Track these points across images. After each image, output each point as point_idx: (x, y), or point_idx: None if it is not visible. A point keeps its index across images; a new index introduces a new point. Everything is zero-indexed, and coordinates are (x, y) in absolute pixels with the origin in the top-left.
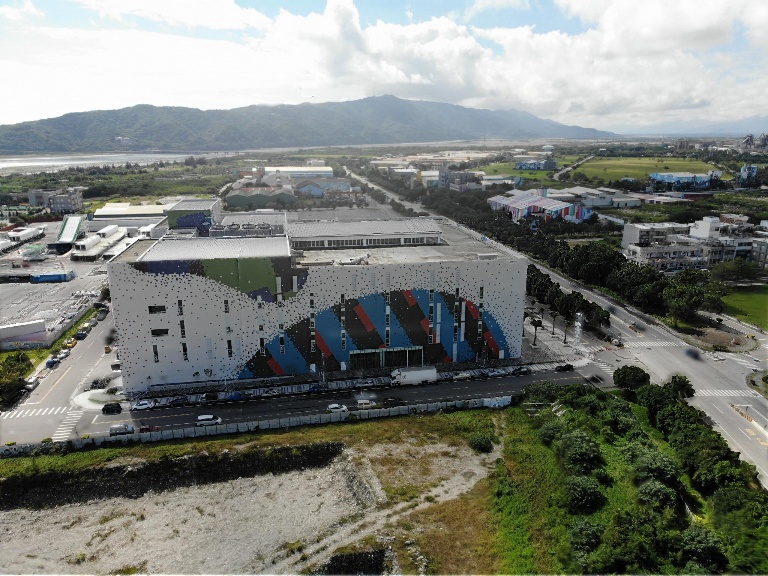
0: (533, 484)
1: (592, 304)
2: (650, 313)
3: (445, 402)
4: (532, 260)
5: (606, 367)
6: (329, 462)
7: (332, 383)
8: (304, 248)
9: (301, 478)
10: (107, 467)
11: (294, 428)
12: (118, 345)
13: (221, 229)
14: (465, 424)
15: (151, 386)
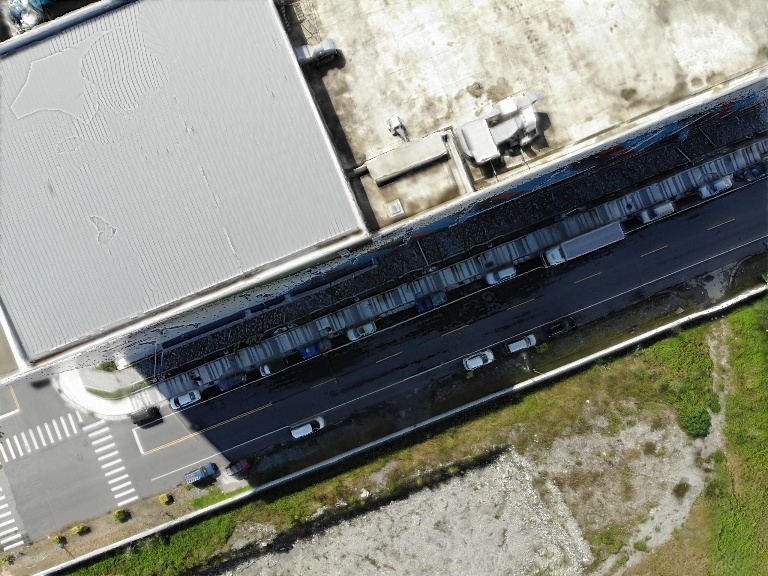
0: (761, 502)
1: None
2: None
3: None
4: None
5: None
6: (493, 459)
7: (444, 271)
8: None
9: (466, 490)
10: (235, 549)
11: (435, 427)
12: None
13: None
14: None
15: (163, 349)
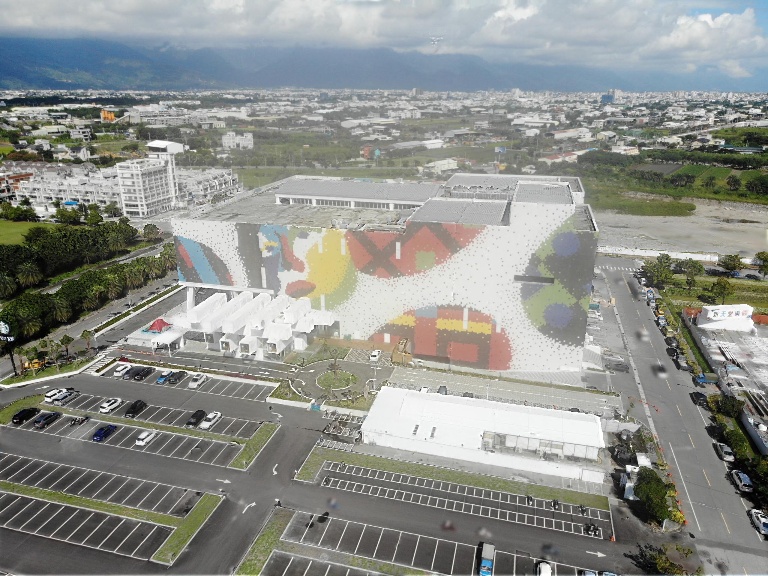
0: None
1: None
2: (130, 251)
3: None
4: None
5: None
6: None
7: None
8: None
9: None
10: None
11: None
12: None
13: None
14: None
15: None
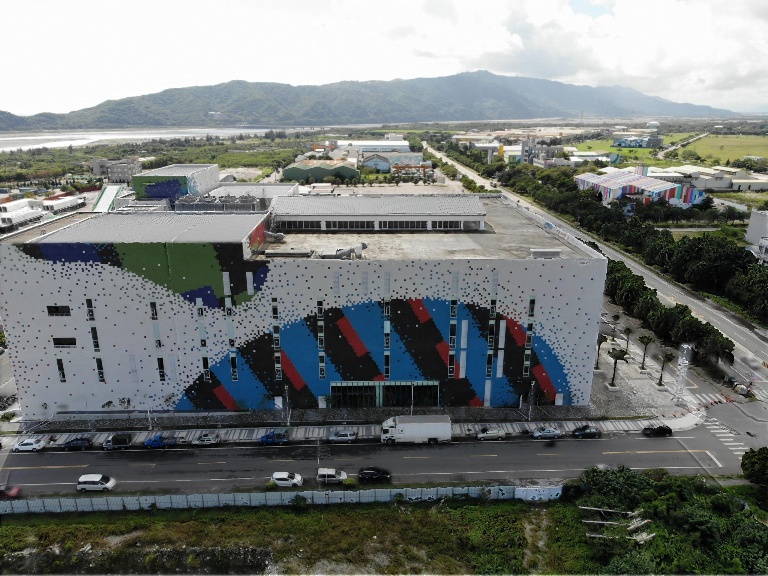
0: None
1: (705, 325)
2: None
3: (450, 488)
4: (622, 253)
5: (726, 435)
6: None
7: (299, 429)
8: (293, 230)
9: None
10: None
11: (207, 512)
12: (10, 356)
13: (191, 201)
14: (473, 539)
15: (56, 413)
